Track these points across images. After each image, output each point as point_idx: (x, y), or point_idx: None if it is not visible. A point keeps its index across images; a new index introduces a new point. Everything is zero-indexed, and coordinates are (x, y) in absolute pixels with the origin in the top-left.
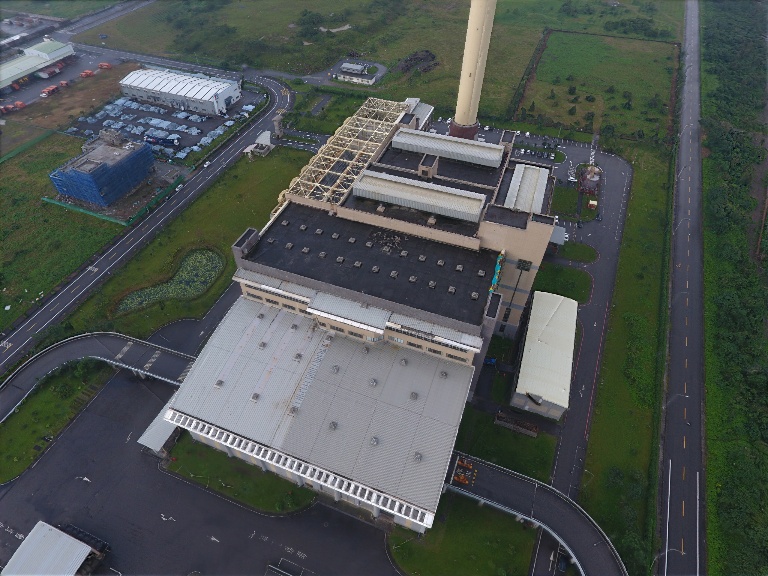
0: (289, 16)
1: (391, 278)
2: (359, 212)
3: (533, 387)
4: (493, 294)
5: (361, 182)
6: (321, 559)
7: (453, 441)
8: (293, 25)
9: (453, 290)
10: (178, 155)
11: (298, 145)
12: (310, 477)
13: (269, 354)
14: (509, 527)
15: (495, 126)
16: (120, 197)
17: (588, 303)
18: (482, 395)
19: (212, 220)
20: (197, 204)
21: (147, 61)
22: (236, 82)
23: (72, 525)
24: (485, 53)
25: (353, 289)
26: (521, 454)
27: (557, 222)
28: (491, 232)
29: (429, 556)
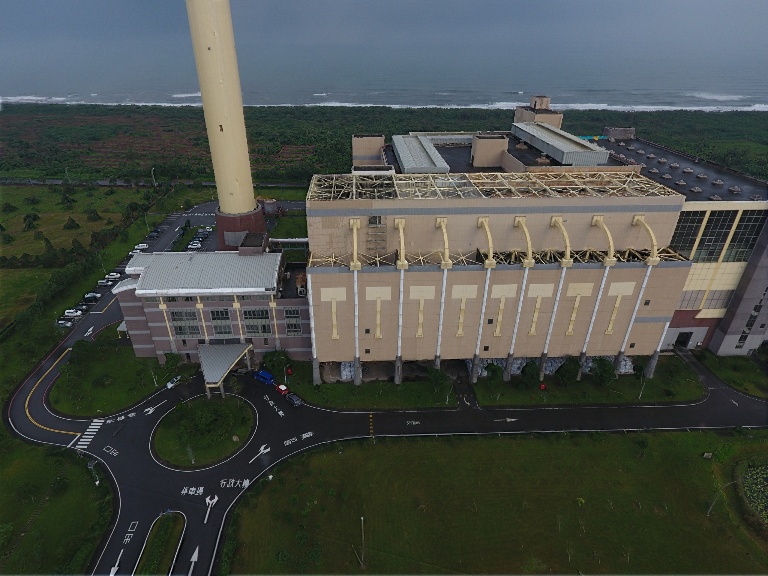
0: None
1: None
2: None
3: None
4: None
5: None
6: None
7: None
8: None
9: None
10: None
11: (191, 573)
12: None
13: None
14: None
15: (108, 270)
16: None
17: None
18: None
19: None
20: None
21: None
22: None
23: None
24: None
25: (701, 165)
26: None
27: None
28: None
29: None
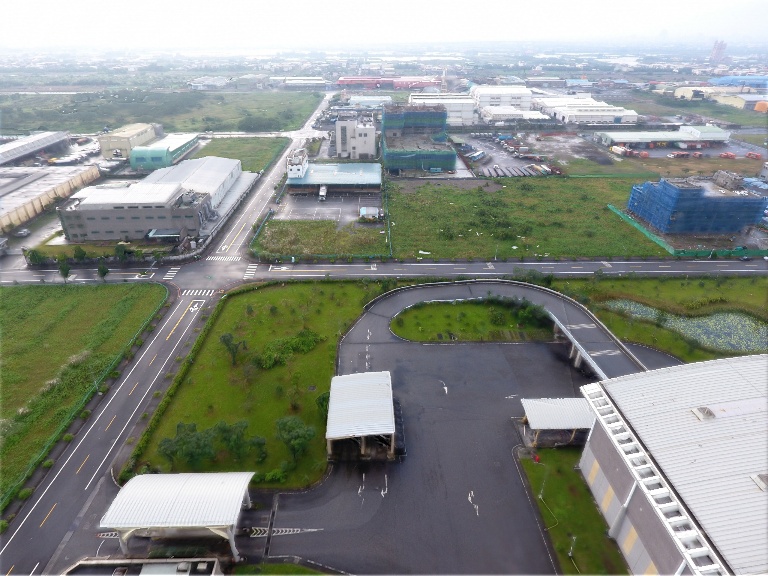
0: None
1: None
2: None
3: None
4: None
5: None
6: None
7: None
8: None
9: None
10: None
11: None
12: None
13: None
14: None
15: None
16: (686, 234)
17: None
18: None
19: None
20: None
21: None
22: None
23: (401, 408)
24: None
25: None
26: None
27: None
28: None
29: None
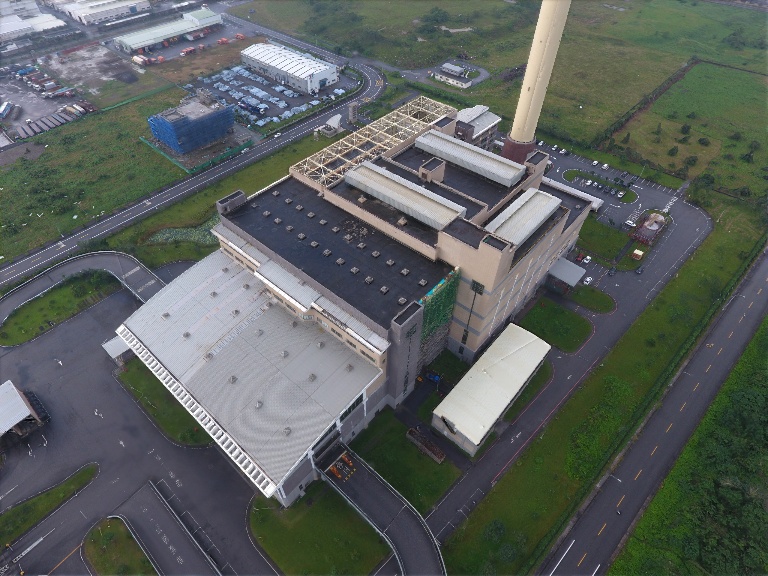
0: (418, 12)
1: (337, 264)
2: (340, 198)
3: (452, 413)
4: (414, 303)
5: (355, 171)
6: (191, 493)
7: (324, 429)
8: (418, 21)
9: (384, 290)
10: (258, 122)
11: None
12: (195, 416)
13: (215, 303)
14: (366, 535)
15: (573, 151)
16: (196, 149)
17: (574, 354)
18: (409, 407)
19: (257, 184)
20: (252, 168)
21: (276, 37)
22: (335, 66)
23: (34, 393)
24: (548, 68)
25: (297, 265)
26: (416, 474)
27: (587, 263)
28: (448, 245)
29: (280, 529)
